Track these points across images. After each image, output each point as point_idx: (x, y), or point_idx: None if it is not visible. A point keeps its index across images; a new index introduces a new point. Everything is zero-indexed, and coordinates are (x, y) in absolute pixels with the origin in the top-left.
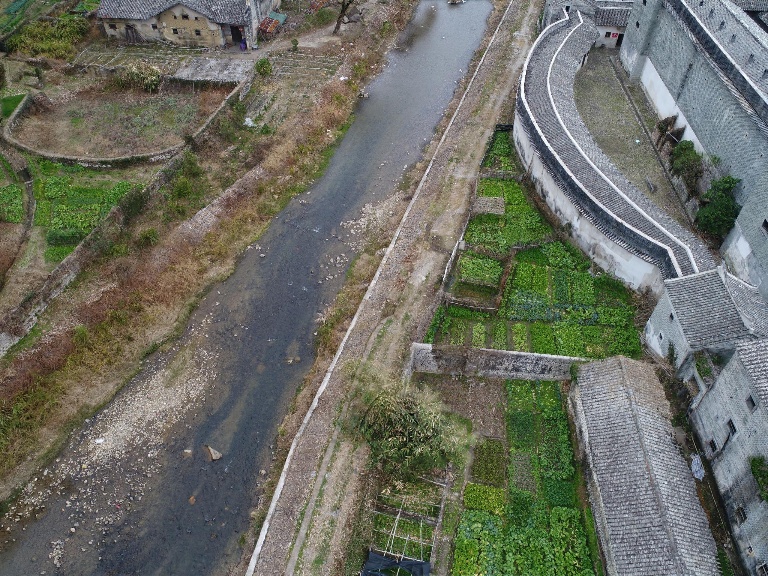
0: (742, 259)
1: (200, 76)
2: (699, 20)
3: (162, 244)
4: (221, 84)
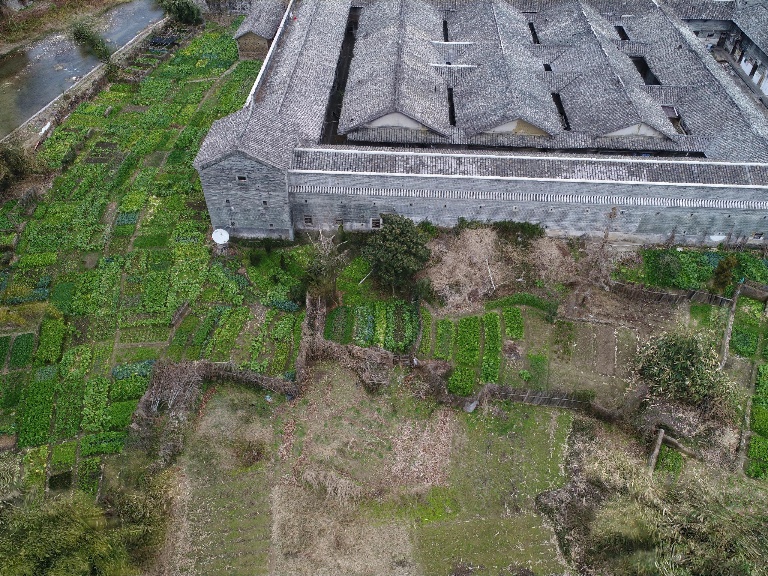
0: None
1: None
2: None
3: None
4: None
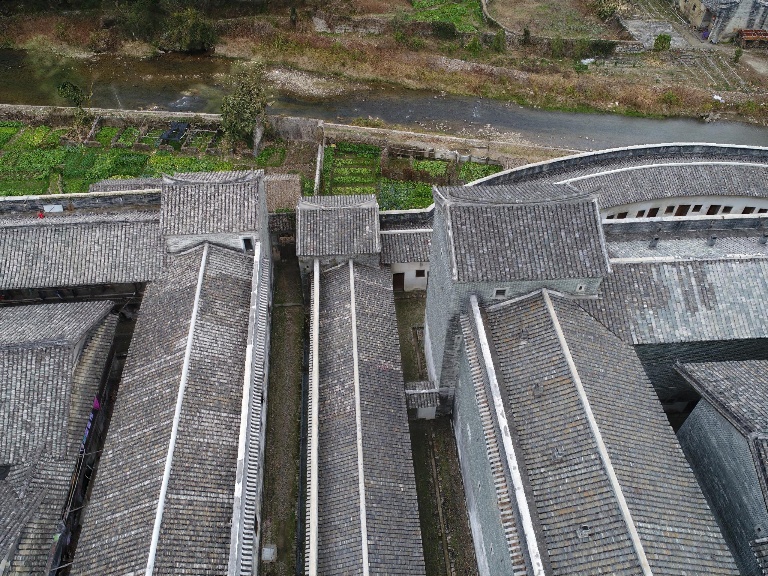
0: None
1: (637, 29)
2: None
3: (420, 54)
4: (631, 38)
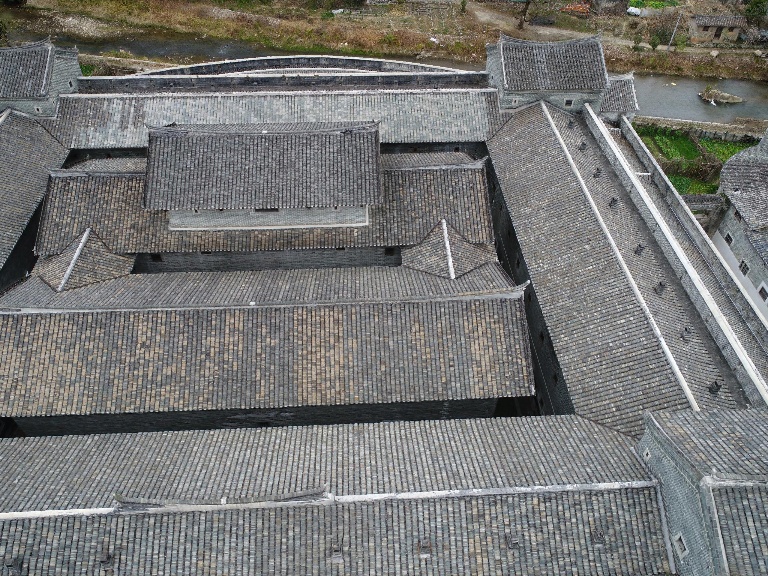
0: None
1: None
2: None
3: (196, 5)
4: None
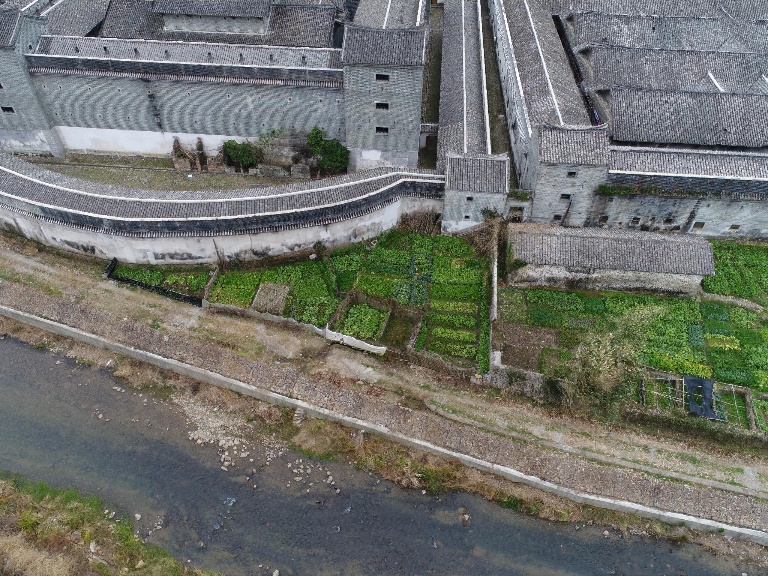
0: (377, 161)
1: None
2: (120, 59)
3: None
4: None
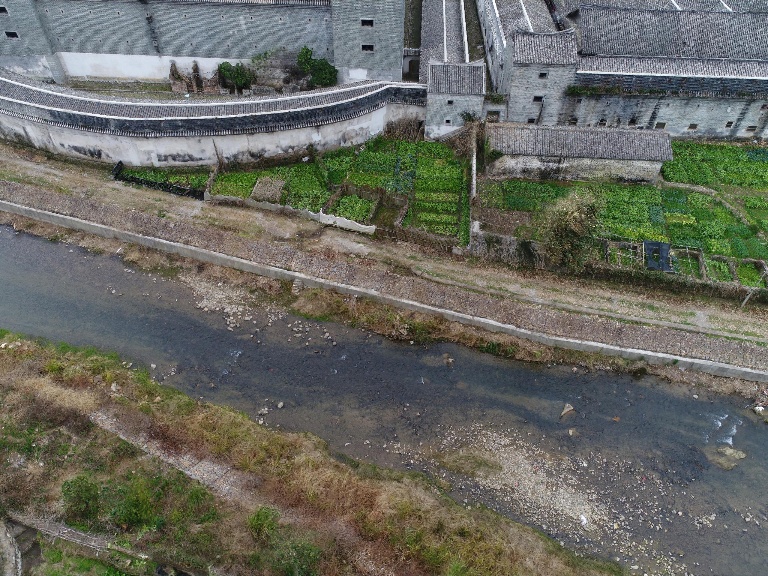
0: None
1: None
2: None
3: None
4: None
